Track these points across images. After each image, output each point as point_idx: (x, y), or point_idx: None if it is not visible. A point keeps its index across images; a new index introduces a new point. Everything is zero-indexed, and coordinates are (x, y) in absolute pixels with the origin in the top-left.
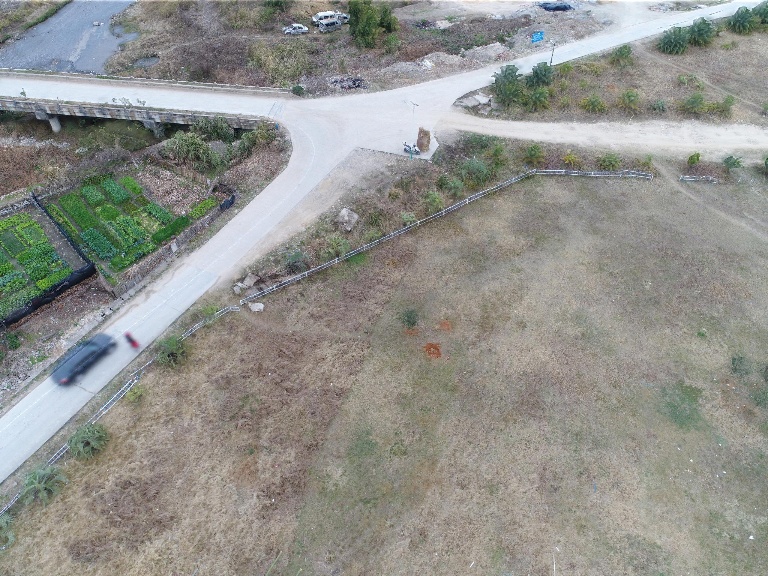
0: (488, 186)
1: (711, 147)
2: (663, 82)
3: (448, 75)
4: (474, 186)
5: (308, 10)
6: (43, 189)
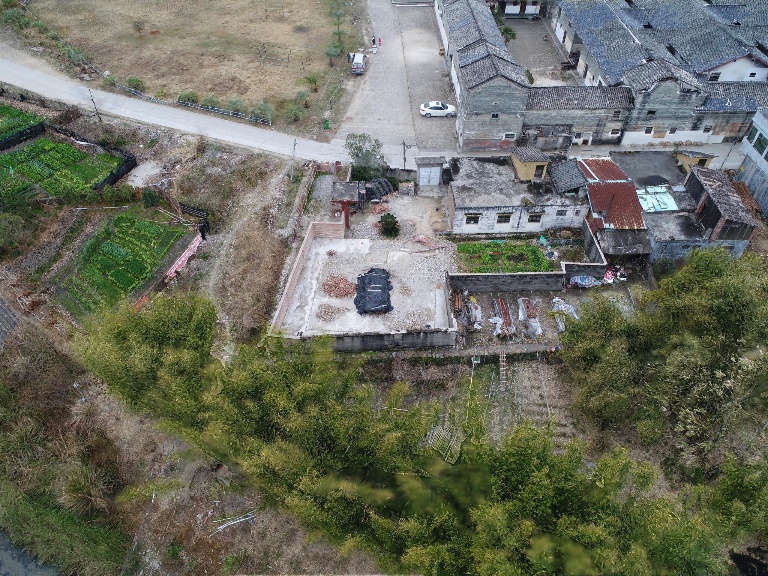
0: None
1: None
2: None
3: None
4: None
5: None
6: None
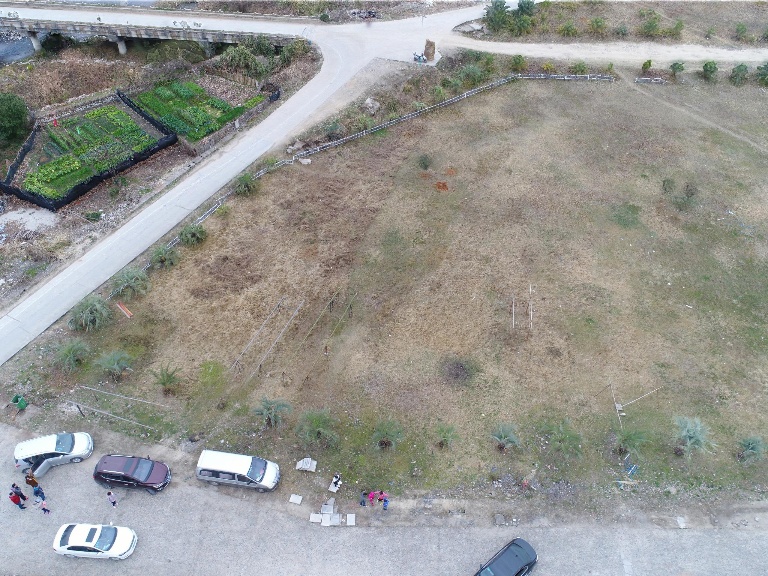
0: (482, 86)
1: (662, 60)
2: (627, 16)
3: (447, 10)
4: (471, 85)
5: None
6: (125, 88)
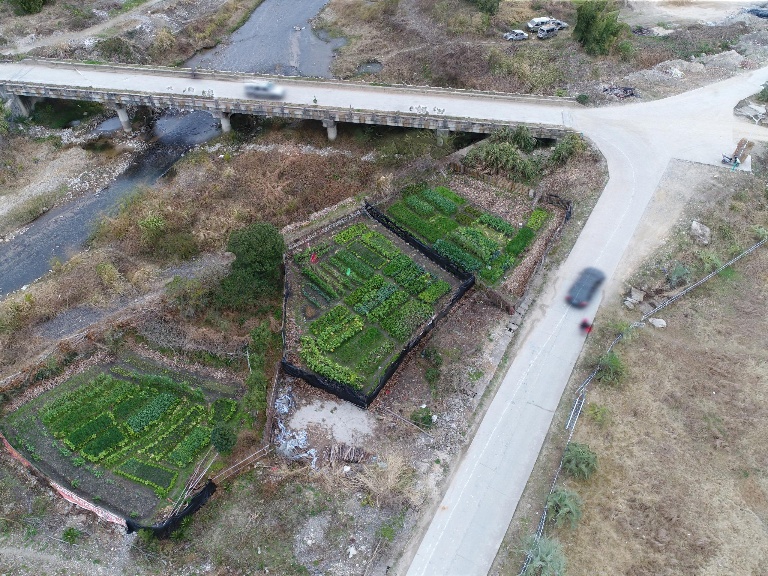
0: None
1: None
2: None
3: (706, 84)
4: None
5: (515, 16)
6: (371, 199)
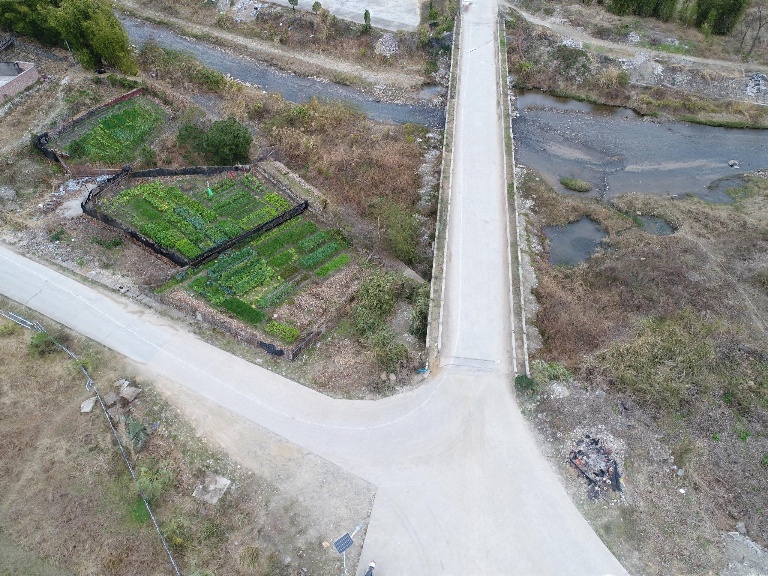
0: None
1: None
2: None
3: None
4: None
5: None
6: None
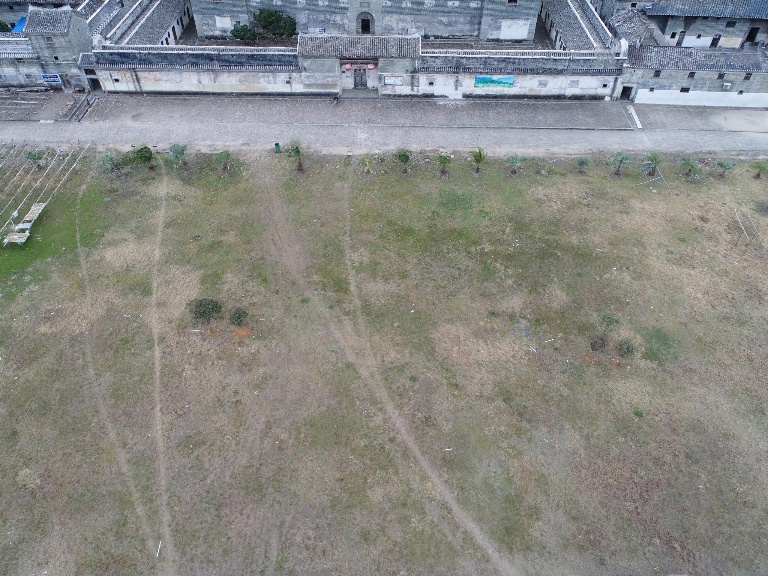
0: None
1: None
2: None
3: None
4: None
5: None
6: None
